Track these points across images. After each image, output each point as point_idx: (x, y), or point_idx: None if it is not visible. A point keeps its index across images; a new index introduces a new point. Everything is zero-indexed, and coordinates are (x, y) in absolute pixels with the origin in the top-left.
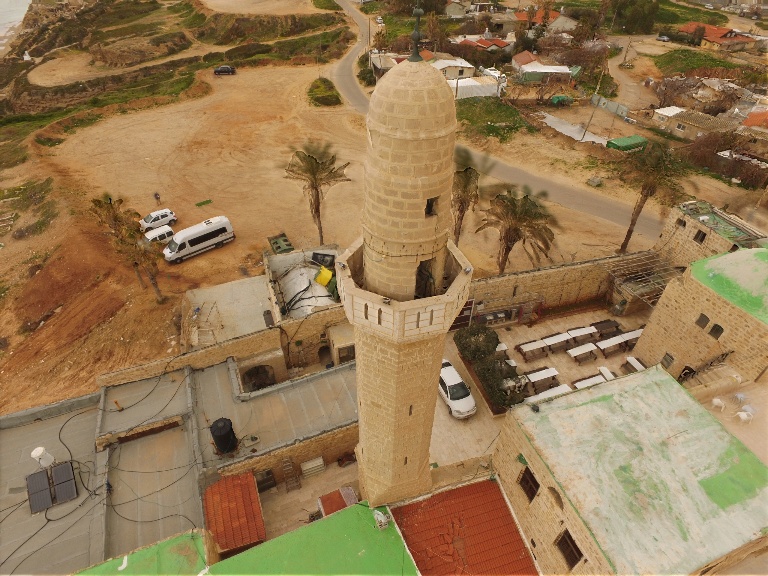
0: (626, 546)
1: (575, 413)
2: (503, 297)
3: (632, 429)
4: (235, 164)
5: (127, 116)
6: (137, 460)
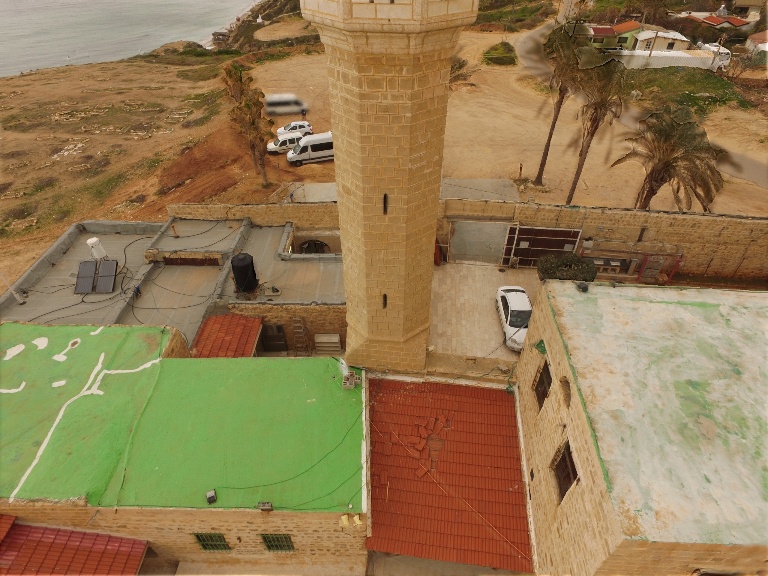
0: (646, 468)
1: (643, 307)
2: (623, 239)
3: (734, 347)
4: None
5: (310, 56)
6: (171, 280)
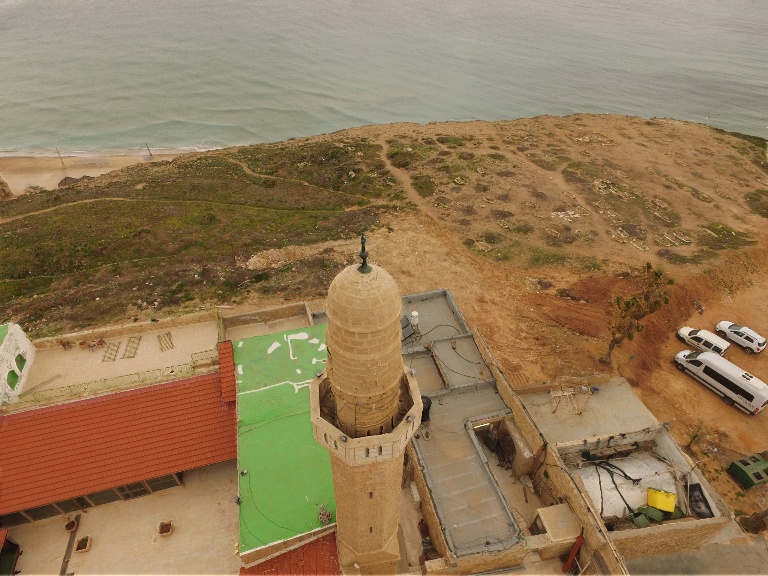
0: None
1: None
2: None
3: None
4: None
5: None
6: (419, 367)
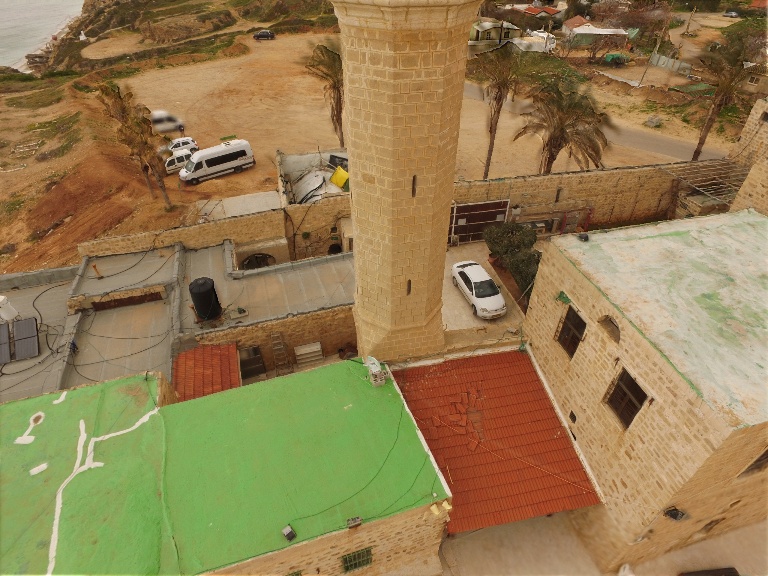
0: (715, 370)
1: (637, 244)
2: (544, 202)
3: (718, 261)
4: (264, 108)
5: (164, 70)
6: (110, 327)
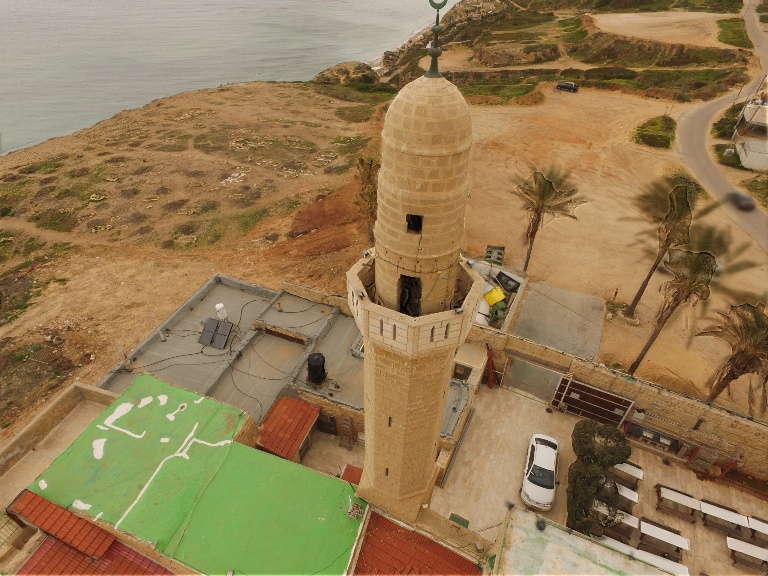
0: None
1: (584, 566)
2: (678, 422)
3: None
4: (513, 172)
5: None
6: (266, 350)
